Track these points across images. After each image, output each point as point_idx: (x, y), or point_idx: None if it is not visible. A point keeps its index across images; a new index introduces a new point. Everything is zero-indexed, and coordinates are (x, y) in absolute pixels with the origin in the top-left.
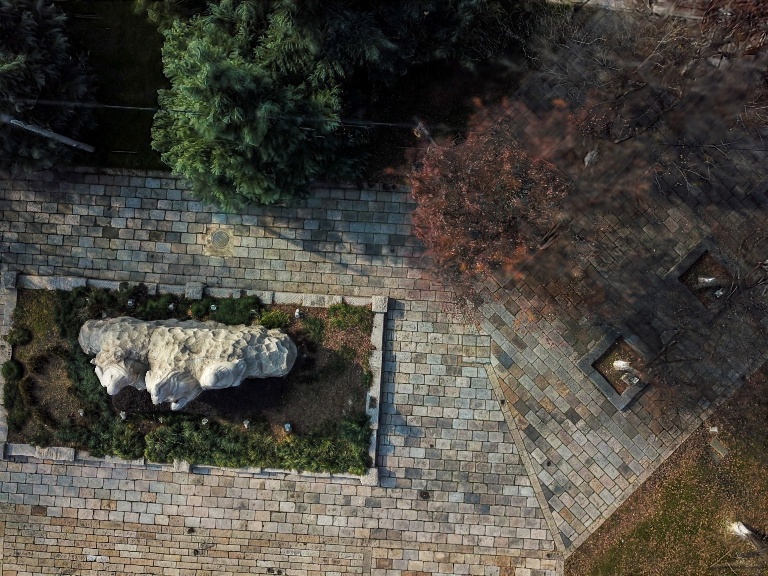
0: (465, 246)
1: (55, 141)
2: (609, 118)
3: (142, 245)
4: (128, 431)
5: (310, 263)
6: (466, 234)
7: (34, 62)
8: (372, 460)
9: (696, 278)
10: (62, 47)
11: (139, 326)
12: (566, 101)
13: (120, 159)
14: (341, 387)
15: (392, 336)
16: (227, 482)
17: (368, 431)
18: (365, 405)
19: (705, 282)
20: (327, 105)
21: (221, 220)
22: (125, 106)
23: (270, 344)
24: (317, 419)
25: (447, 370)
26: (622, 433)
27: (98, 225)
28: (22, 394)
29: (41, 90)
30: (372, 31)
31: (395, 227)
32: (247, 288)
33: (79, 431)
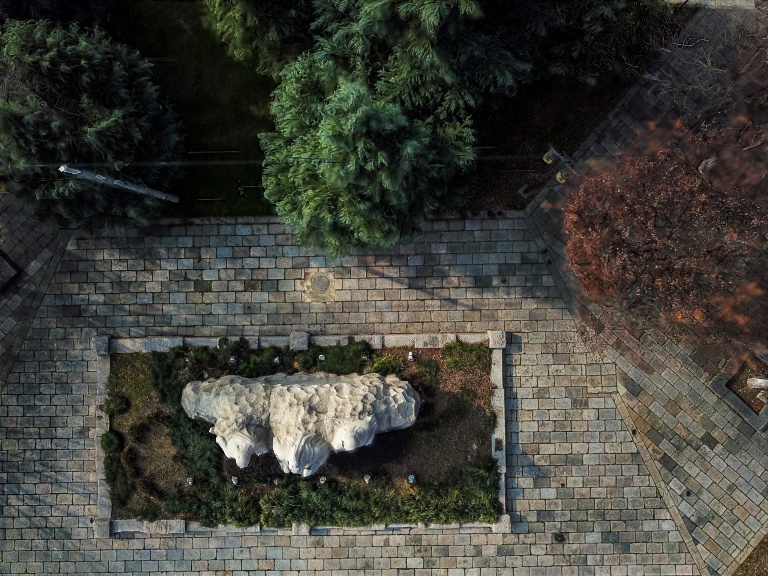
0: (652, 285)
1: (151, 197)
2: (719, 123)
3: (237, 296)
4: (242, 497)
5: (417, 301)
6: (651, 272)
7: (127, 115)
8: (502, 506)
9: None
10: (153, 96)
11: (254, 387)
12: (672, 108)
13: (207, 207)
14: (464, 431)
15: (511, 372)
16: (349, 542)
17: (496, 476)
18: (491, 448)
19: None
20: (458, 138)
21: (319, 263)
22: (209, 151)
23: (397, 395)
24: (441, 467)
25: (572, 403)
26: (763, 455)
27: (189, 279)
28: (125, 467)
29: (136, 145)
30: (502, 55)
31: (504, 256)
32: (353, 333)
33: (189, 501)
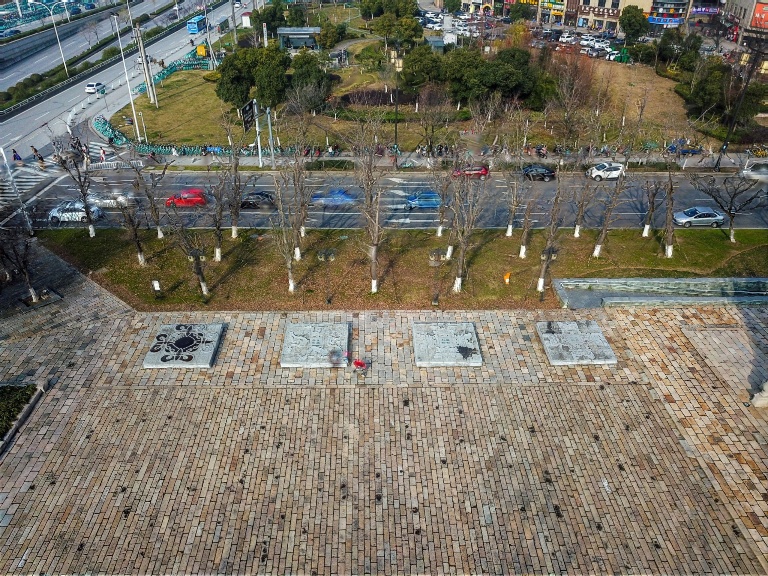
0: None
1: None
2: None
3: None
4: None
5: None
6: None
7: None
8: None
9: (6, 281)
10: None
11: None
12: None
13: None
14: None
15: None
16: (4, 467)
17: (7, 386)
18: None
19: (9, 277)
20: None
21: None
22: None
23: None
24: None
25: None
26: None
27: None
28: None
29: None
30: None
31: None
32: None
33: None
